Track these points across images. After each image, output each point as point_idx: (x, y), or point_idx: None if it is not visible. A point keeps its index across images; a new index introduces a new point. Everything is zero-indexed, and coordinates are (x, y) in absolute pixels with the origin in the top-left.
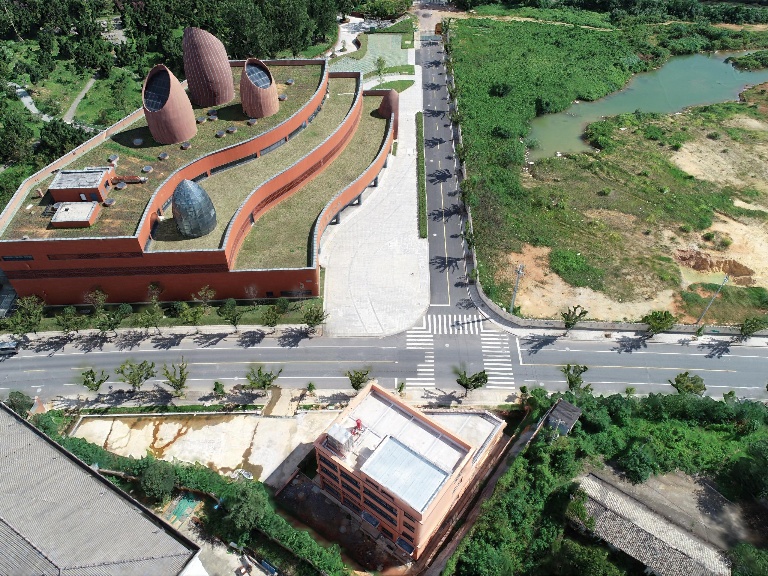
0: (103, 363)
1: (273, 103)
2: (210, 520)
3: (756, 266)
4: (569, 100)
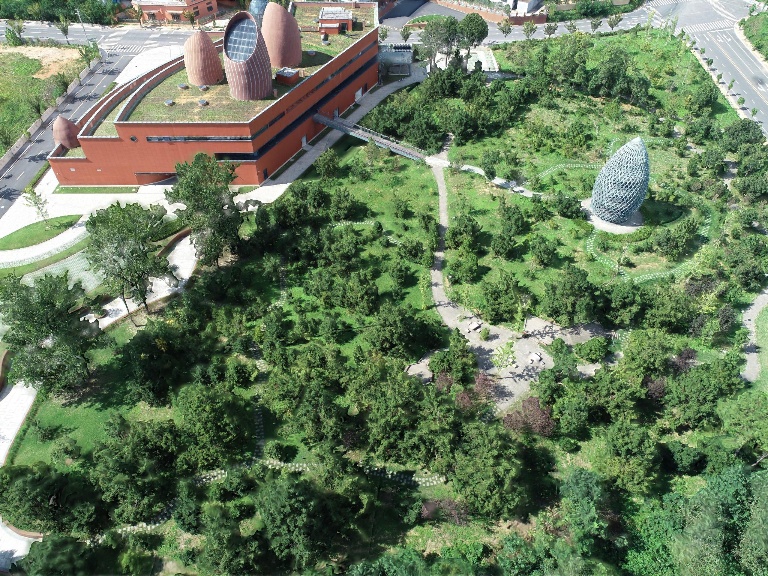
0: None
1: None
2: None
3: None
4: None
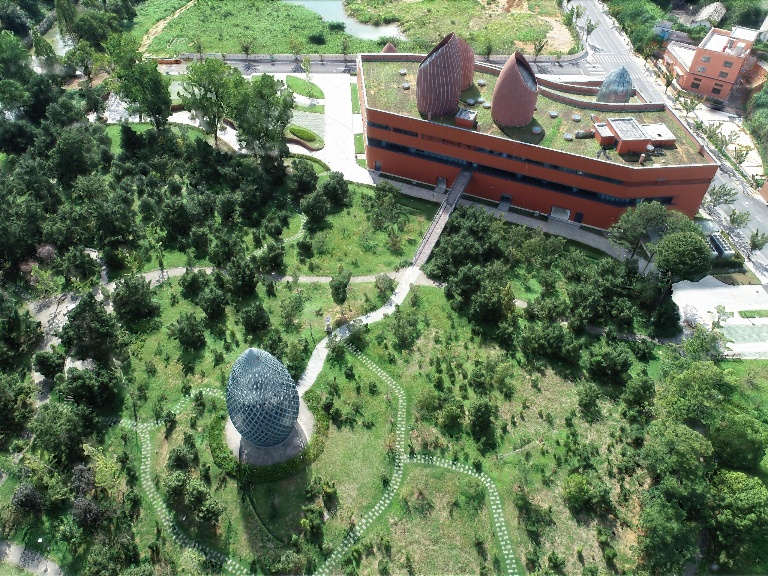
0: None
1: None
2: None
3: None
4: None
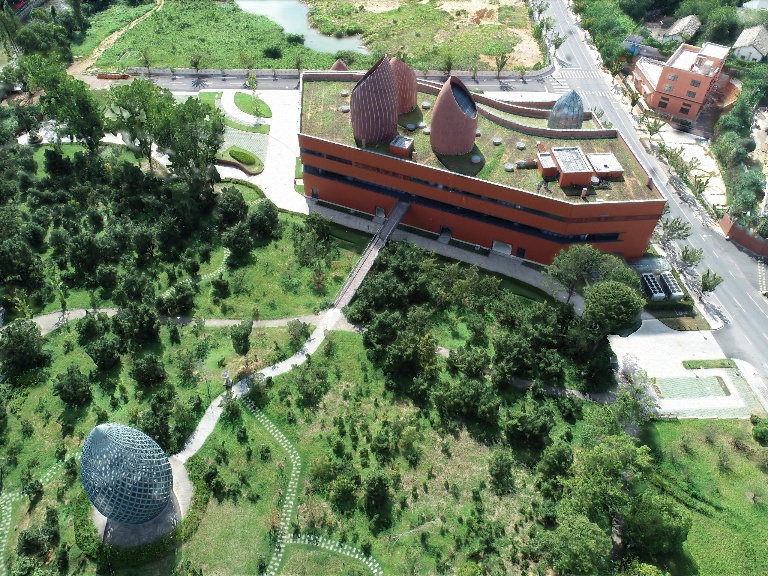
0: None
1: None
2: None
3: (480, 7)
4: None
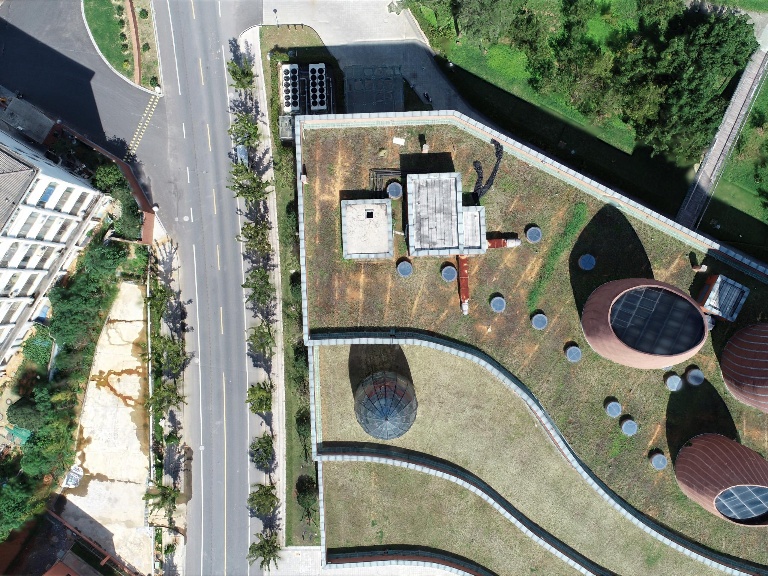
0: (226, 281)
1: None
2: (5, 466)
3: None
4: None
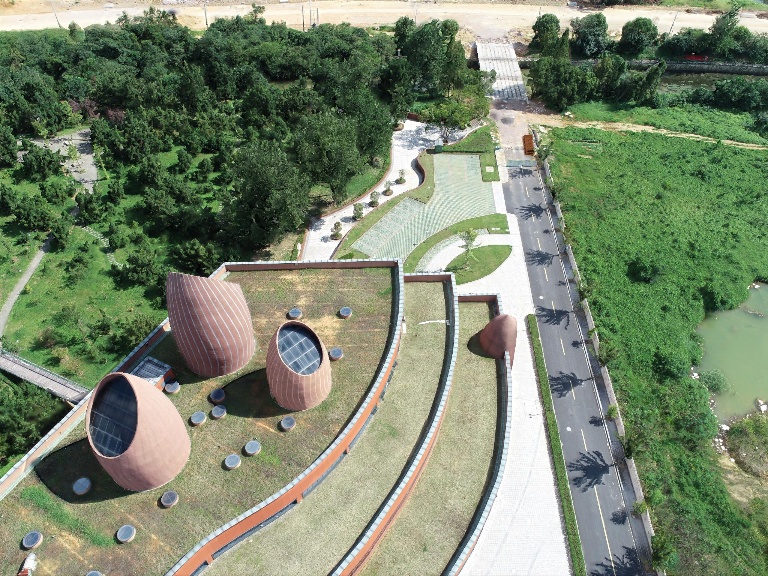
0: None
1: (323, 387)
2: None
3: None
4: (745, 285)
